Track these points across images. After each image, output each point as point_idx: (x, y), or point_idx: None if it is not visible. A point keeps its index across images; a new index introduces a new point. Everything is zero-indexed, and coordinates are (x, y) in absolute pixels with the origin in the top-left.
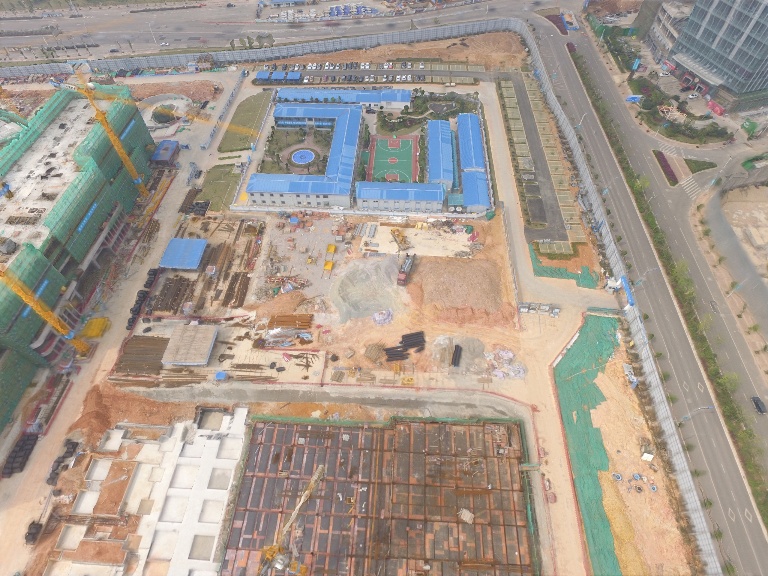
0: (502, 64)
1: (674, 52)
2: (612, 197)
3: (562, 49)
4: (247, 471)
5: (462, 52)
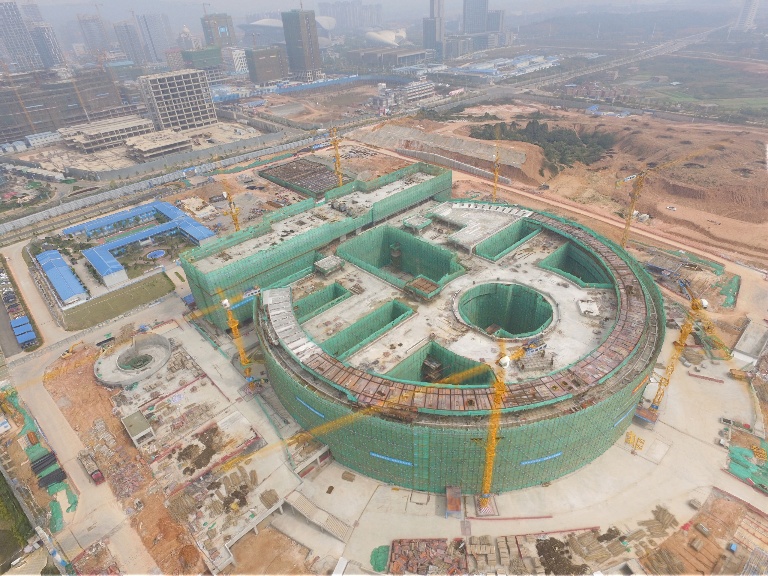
0: None
1: None
2: None
3: None
4: None
5: None
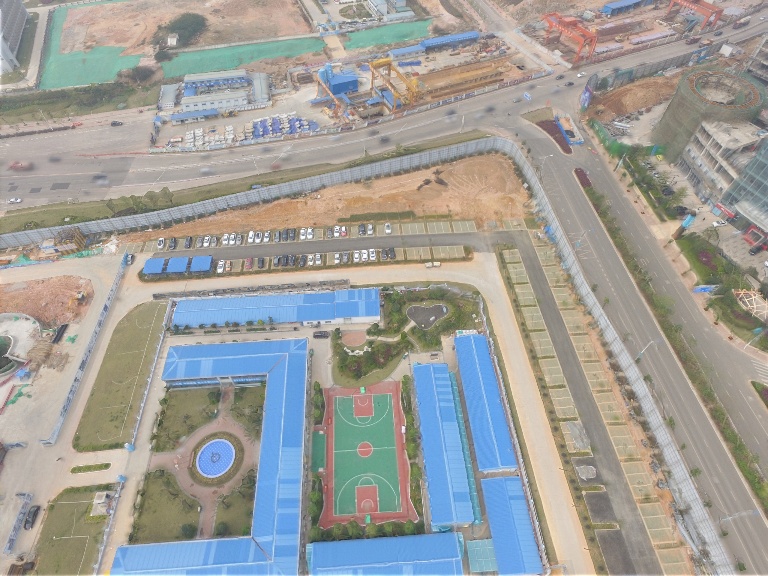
0: (498, 216)
1: (732, 196)
2: (726, 506)
3: (570, 179)
4: None
5: (440, 196)
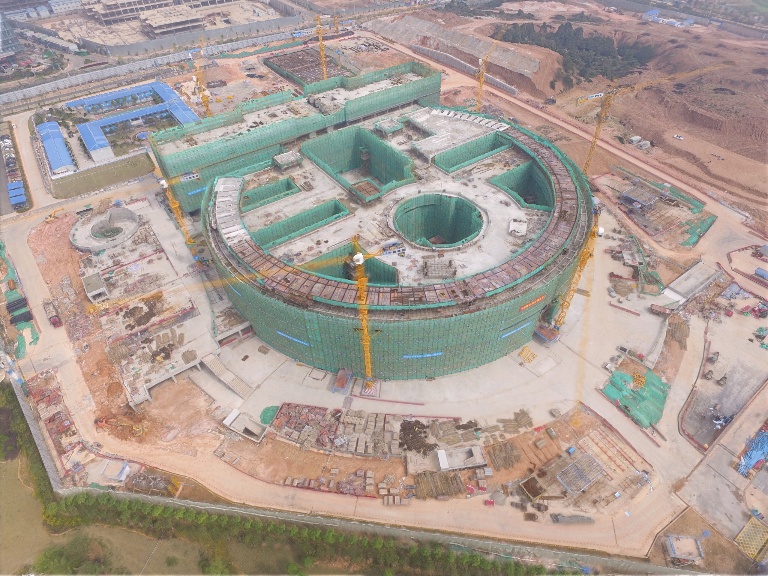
0: None
1: None
2: None
3: None
4: None
5: None
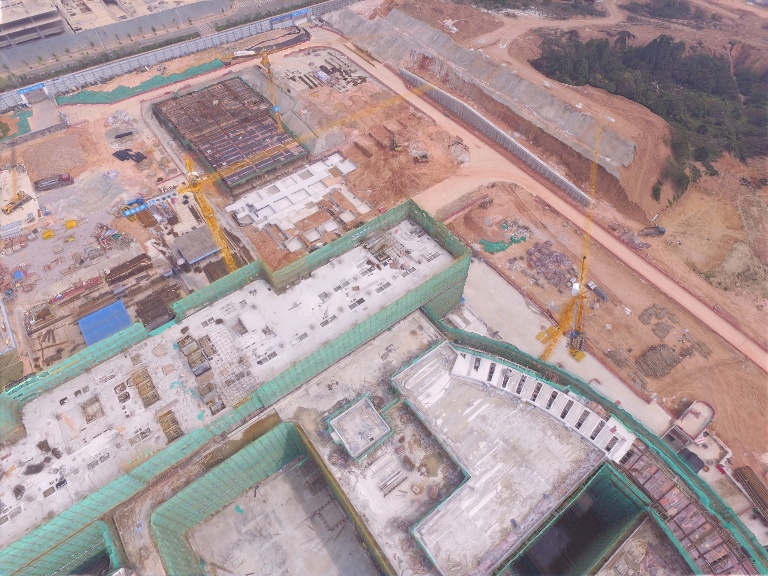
0: None
1: None
2: None
3: None
4: (257, 171)
5: None
